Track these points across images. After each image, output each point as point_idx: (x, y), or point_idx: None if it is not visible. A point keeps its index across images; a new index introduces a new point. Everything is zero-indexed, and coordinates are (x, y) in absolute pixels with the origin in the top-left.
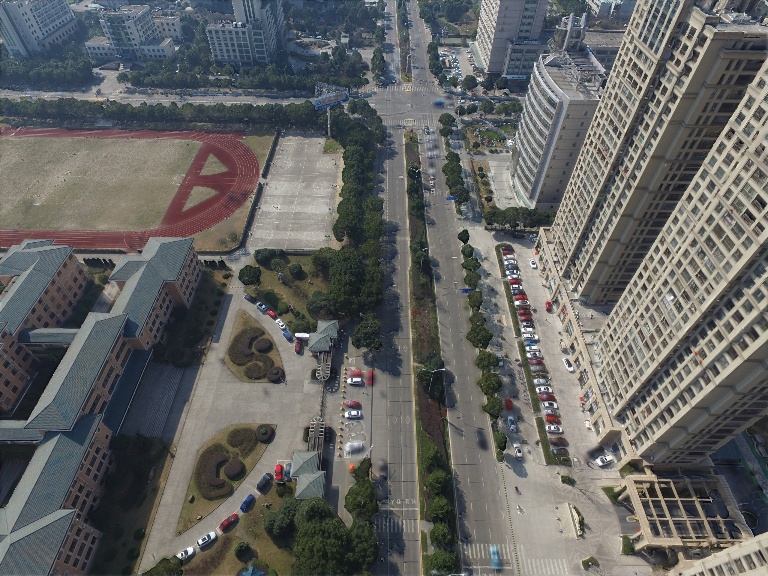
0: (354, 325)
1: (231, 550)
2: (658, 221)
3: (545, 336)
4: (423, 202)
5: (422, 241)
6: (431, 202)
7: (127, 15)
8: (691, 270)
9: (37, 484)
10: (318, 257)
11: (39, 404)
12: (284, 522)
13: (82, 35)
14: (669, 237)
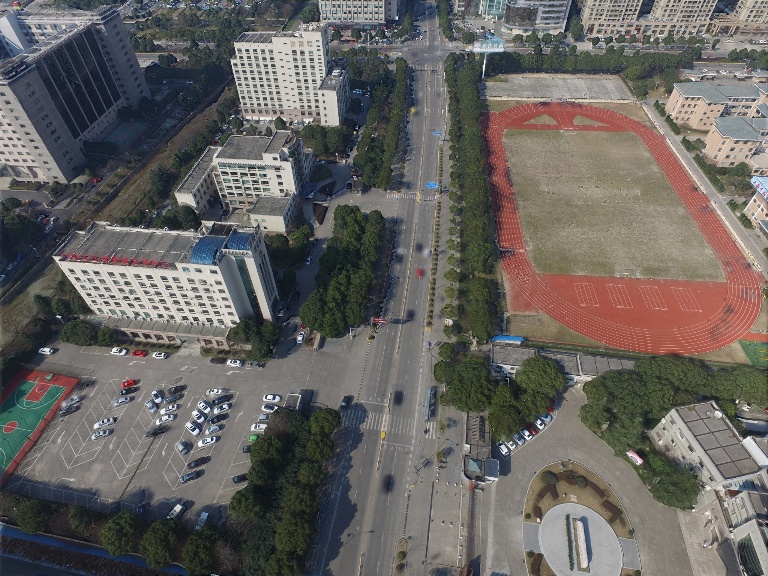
0: None
1: None
2: None
3: None
4: None
5: None
6: None
7: None
8: None
9: None
10: None
11: None
12: None
13: None
14: None
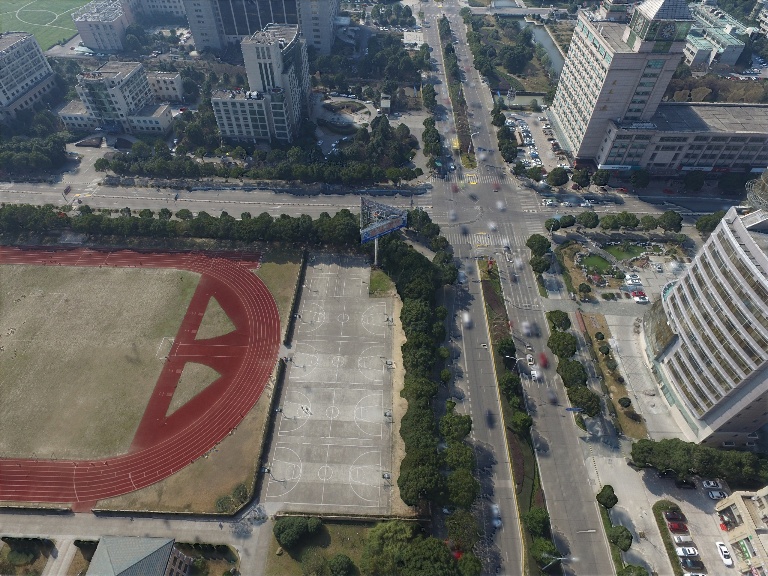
0: None
1: None
2: None
3: None
4: (523, 401)
5: (545, 516)
6: (535, 400)
7: (110, 80)
8: None
9: None
10: (381, 570)
11: None
12: None
13: (60, 94)
14: None
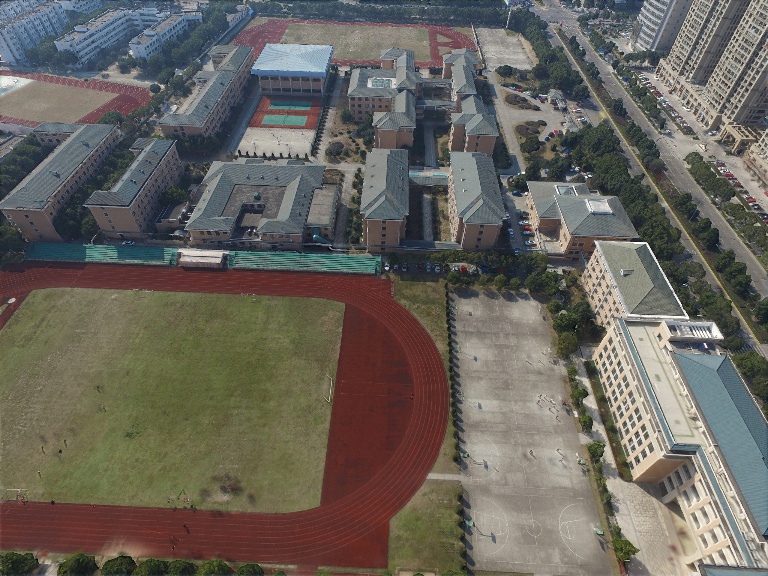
0: (566, 96)
1: (548, 149)
2: (740, 20)
3: (671, 101)
4: None
5: None
6: (585, 56)
7: None
8: (764, 11)
9: (476, 105)
10: (542, 64)
11: (457, 86)
12: (573, 136)
13: None
14: (752, 8)
